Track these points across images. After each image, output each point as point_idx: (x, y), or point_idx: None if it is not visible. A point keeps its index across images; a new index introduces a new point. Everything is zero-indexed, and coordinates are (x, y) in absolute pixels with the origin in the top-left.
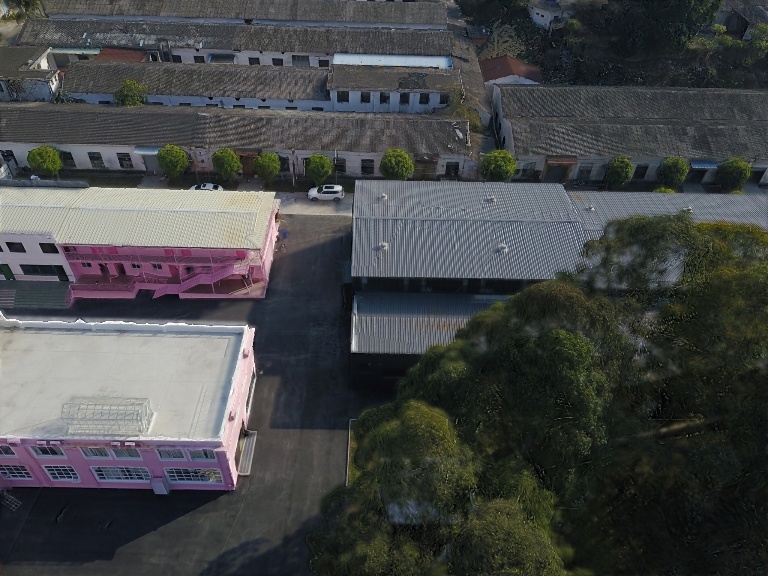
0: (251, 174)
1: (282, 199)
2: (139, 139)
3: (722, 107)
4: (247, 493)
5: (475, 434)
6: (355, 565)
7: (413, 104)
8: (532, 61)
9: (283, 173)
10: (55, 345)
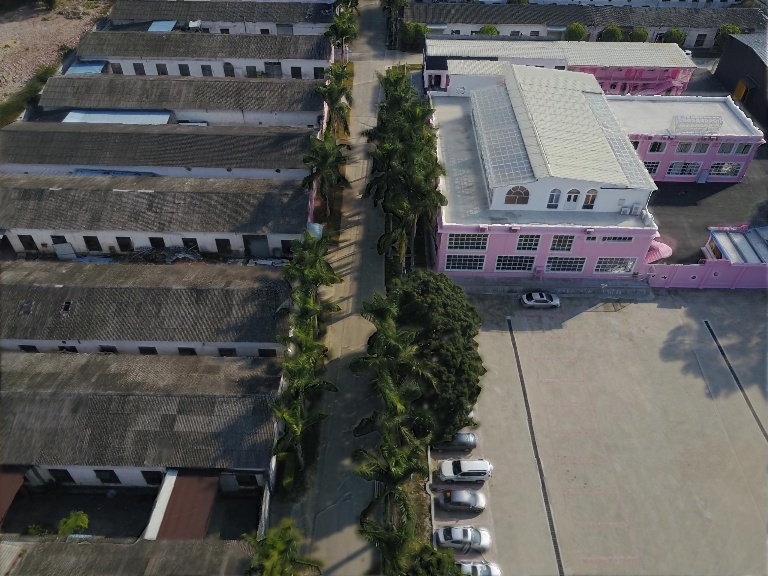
0: None
1: None
2: (549, 21)
3: None
4: (749, 183)
5: None
6: None
7: (716, 2)
8: None
9: None
10: (621, 106)
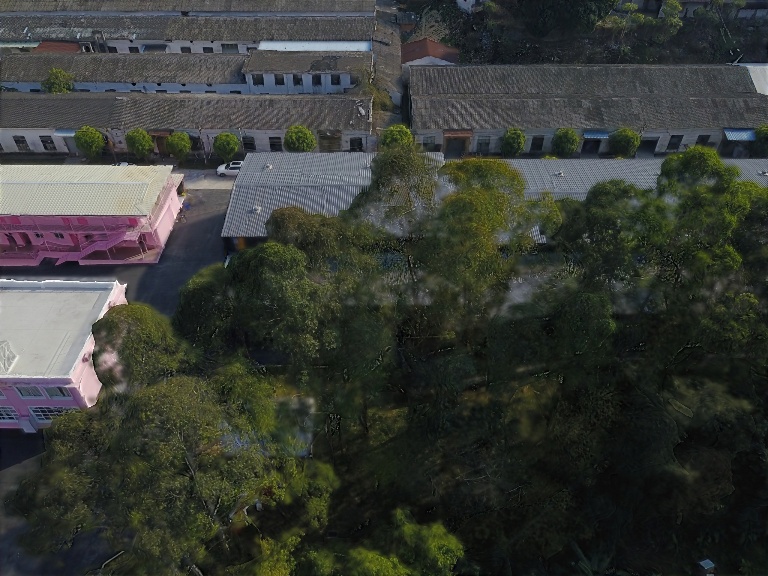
0: (167, 154)
1: (193, 176)
2: (59, 122)
3: (625, 81)
4: None
5: (211, 339)
6: (50, 429)
7: (325, 85)
8: (454, 44)
9: (197, 152)
10: None
